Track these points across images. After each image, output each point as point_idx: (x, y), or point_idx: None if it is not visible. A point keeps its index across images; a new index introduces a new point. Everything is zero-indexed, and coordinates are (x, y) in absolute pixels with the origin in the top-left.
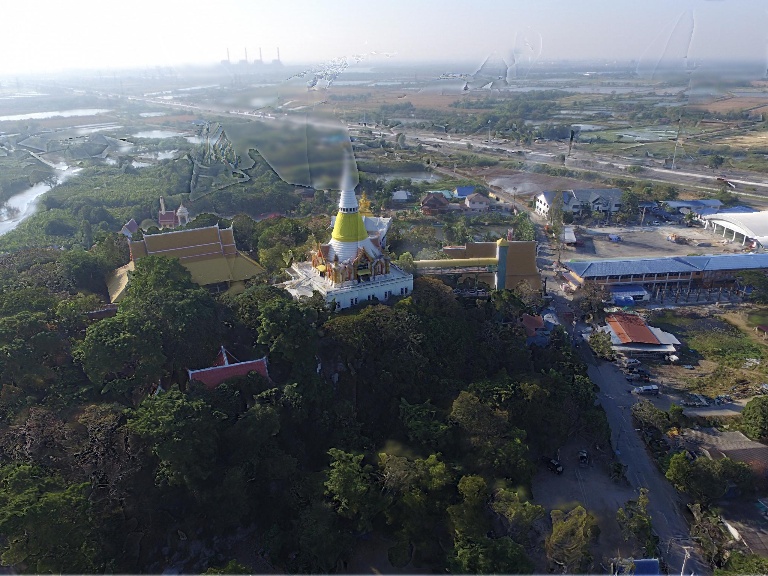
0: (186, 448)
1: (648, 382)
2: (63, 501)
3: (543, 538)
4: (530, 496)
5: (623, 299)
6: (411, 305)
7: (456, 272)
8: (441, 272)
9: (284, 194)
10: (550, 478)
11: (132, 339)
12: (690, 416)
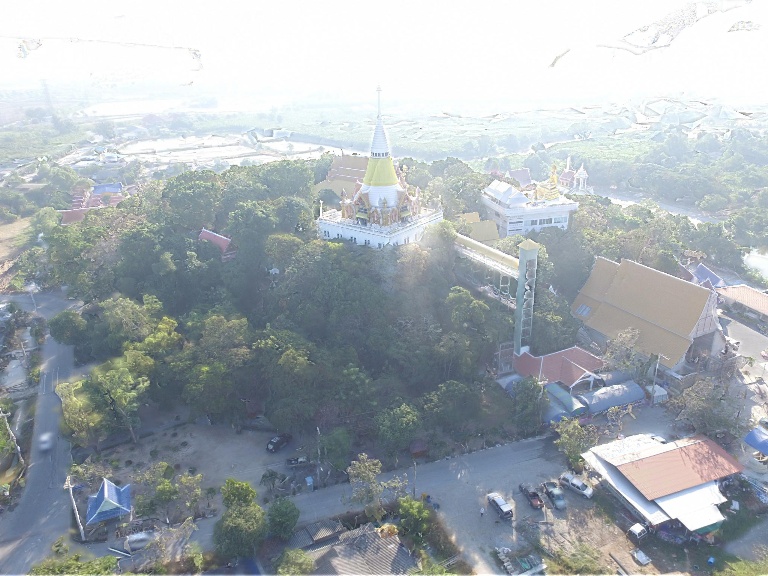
0: (122, 252)
1: (533, 507)
2: (75, 245)
3: (171, 453)
4: (190, 418)
5: (761, 437)
6: (339, 251)
7: (485, 262)
8: (474, 256)
9: (703, 181)
10: (262, 447)
11: (190, 195)
12: (464, 556)
